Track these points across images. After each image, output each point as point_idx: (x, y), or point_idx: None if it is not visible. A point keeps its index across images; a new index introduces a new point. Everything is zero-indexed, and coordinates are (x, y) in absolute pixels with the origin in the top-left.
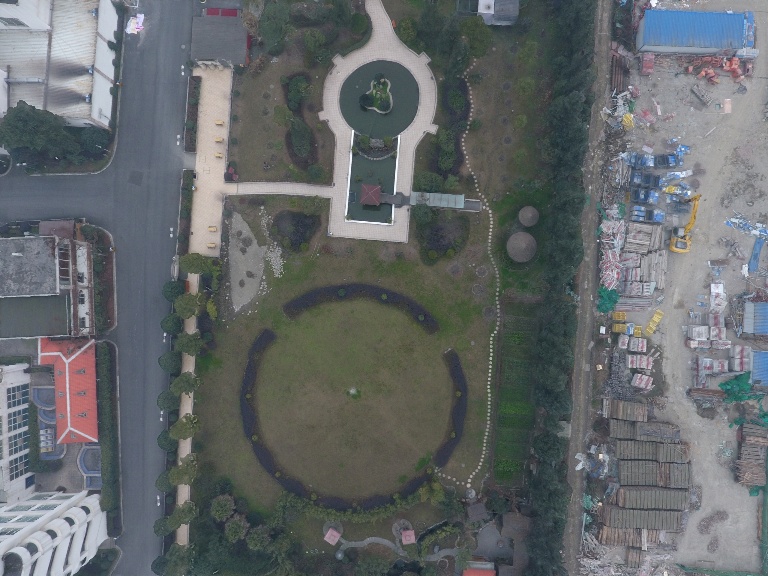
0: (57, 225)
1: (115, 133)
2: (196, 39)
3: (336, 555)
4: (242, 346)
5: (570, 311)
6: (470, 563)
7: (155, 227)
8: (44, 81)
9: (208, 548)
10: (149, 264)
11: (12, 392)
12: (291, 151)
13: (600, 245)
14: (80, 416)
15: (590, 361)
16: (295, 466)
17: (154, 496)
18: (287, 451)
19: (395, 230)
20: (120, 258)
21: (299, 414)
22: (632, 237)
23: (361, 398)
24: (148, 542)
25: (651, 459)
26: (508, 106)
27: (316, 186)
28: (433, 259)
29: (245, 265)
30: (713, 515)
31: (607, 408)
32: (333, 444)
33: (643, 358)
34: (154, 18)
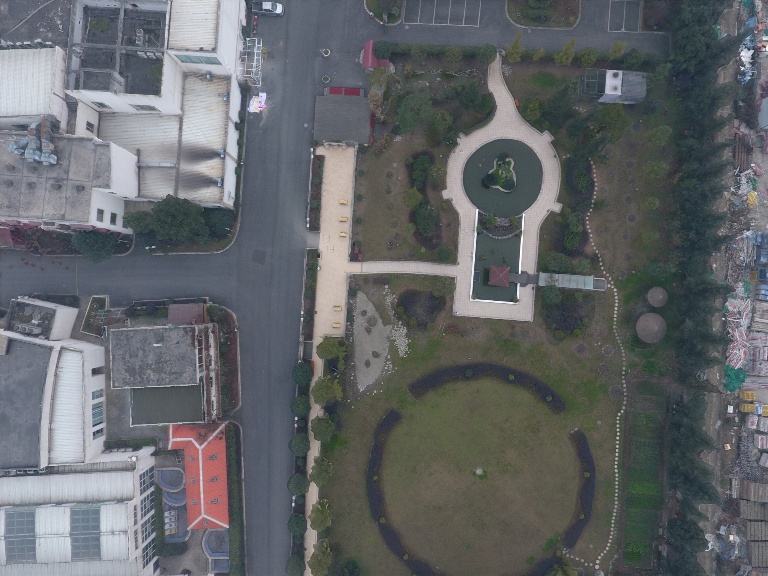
0: (186, 308)
1: (238, 212)
2: (319, 118)
3: None
4: (367, 426)
5: None
6: None
7: (279, 306)
8: (176, 165)
9: None
10: (273, 344)
11: (143, 478)
12: (416, 230)
13: (726, 323)
14: (212, 503)
15: (717, 440)
16: (421, 548)
17: None
18: (413, 532)
19: (520, 309)
20: (244, 338)
21: (425, 495)
22: (760, 316)
23: (487, 478)
24: None
25: None
26: (632, 184)
27: (440, 265)
28: (560, 339)
29: (371, 345)
30: None
31: (736, 488)
32: (460, 525)
33: None
34: (276, 97)
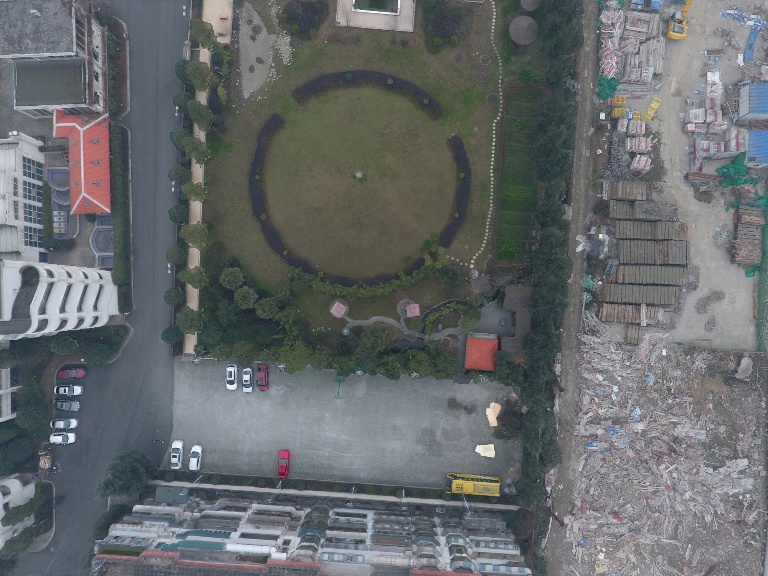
0: None
1: None
2: None
3: (342, 331)
4: (251, 131)
5: (571, 93)
6: (473, 334)
7: (168, 17)
8: None
9: (217, 315)
10: (161, 52)
11: (27, 163)
12: None
13: (600, 35)
14: (94, 184)
15: (590, 147)
16: (302, 247)
17: (164, 275)
18: (295, 233)
19: (401, 20)
20: (133, 46)
21: (307, 197)
22: (631, 25)
23: (367, 182)
24: (158, 320)
25: (650, 239)
26: None
27: None
28: (438, 46)
29: (255, 51)
30: (710, 295)
31: (607, 191)
32: (340, 226)
33: (642, 139)
34: None
